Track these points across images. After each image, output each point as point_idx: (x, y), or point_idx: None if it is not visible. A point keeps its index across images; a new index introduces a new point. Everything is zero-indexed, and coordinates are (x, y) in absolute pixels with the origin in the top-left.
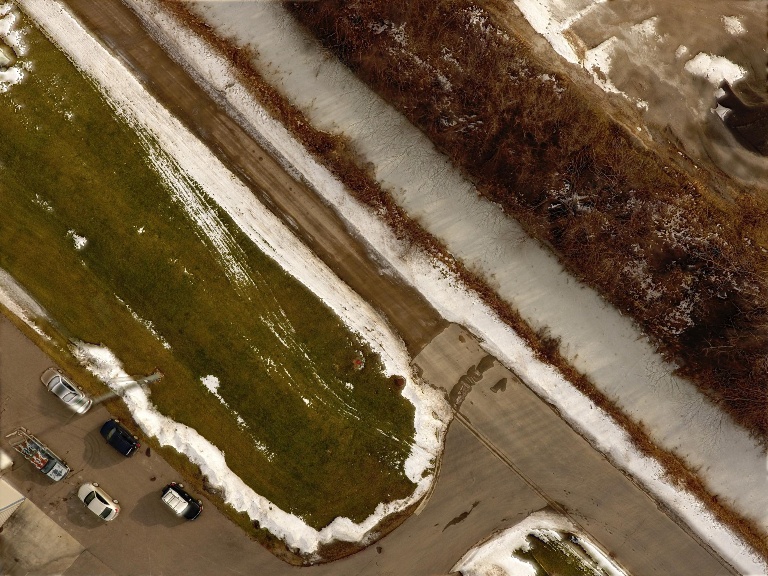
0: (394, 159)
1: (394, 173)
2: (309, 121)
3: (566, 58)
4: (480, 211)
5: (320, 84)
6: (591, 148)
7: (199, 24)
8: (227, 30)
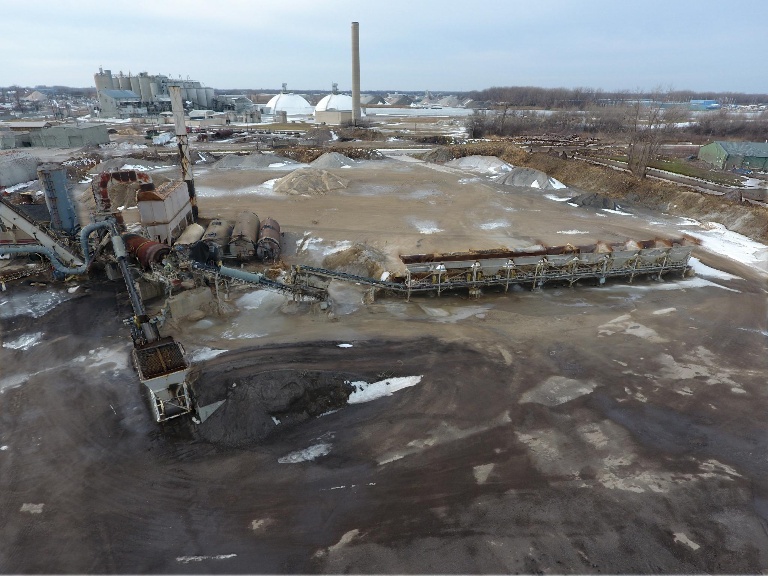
0: None
1: None
2: None
3: None
4: None
5: None
6: None
7: None
8: None
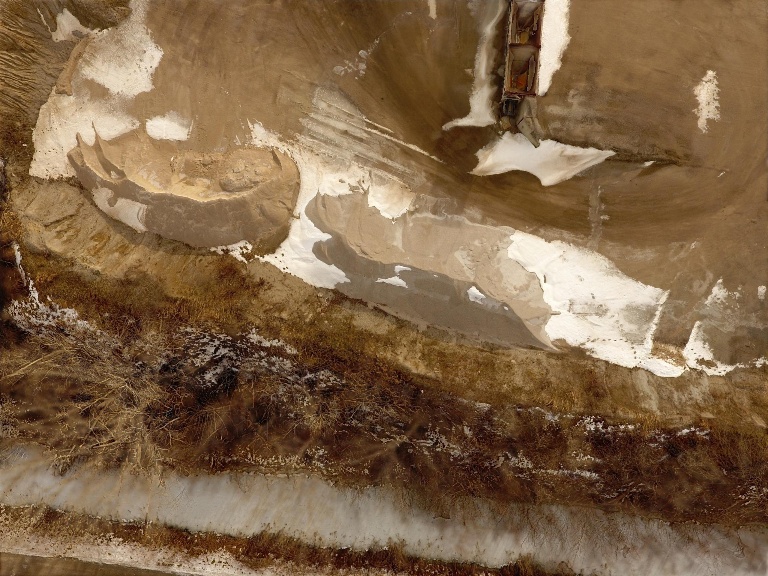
0: (578, 546)
1: (586, 557)
2: (486, 566)
3: (673, 376)
4: (679, 537)
5: (472, 529)
6: (764, 462)
7: (338, 553)
8: (363, 540)
